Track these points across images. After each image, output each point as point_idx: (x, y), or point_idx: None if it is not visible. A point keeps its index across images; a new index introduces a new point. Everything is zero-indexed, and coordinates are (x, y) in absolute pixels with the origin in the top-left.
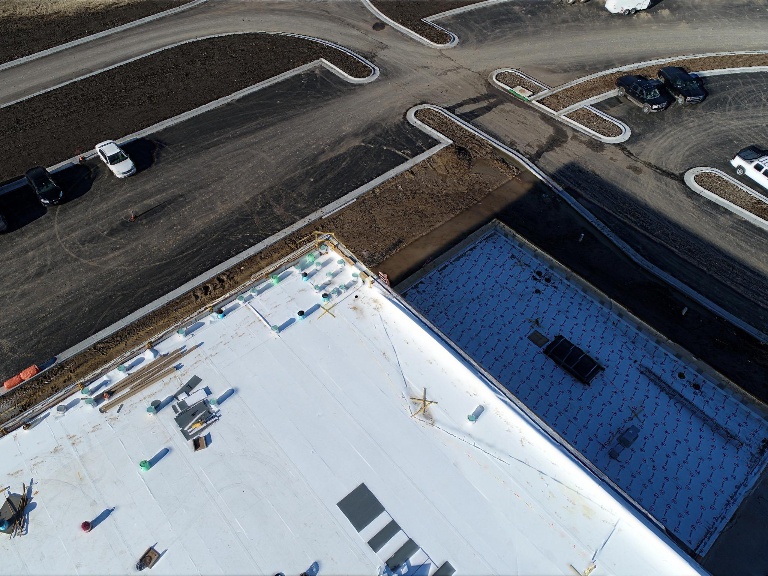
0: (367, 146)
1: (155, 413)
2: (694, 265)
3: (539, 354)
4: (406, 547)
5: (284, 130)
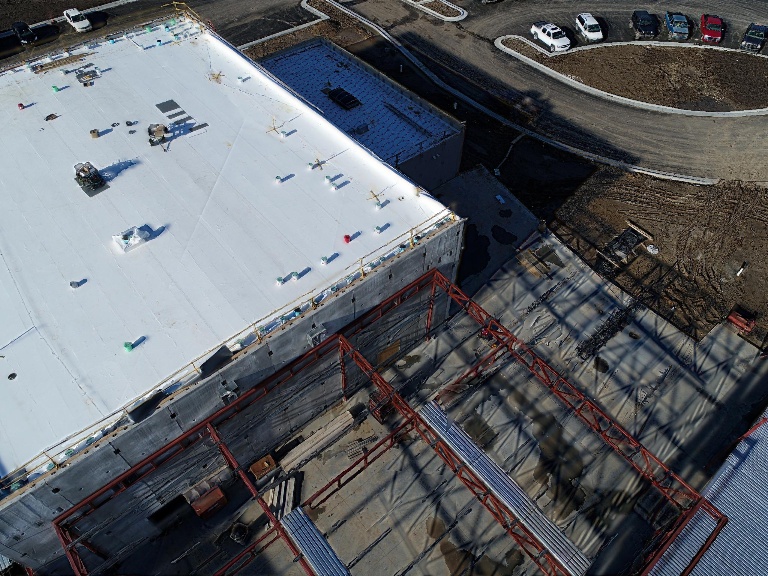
0: (266, 19)
1: (65, 74)
2: (478, 86)
3: (324, 97)
4: (186, 118)
5: (206, 9)
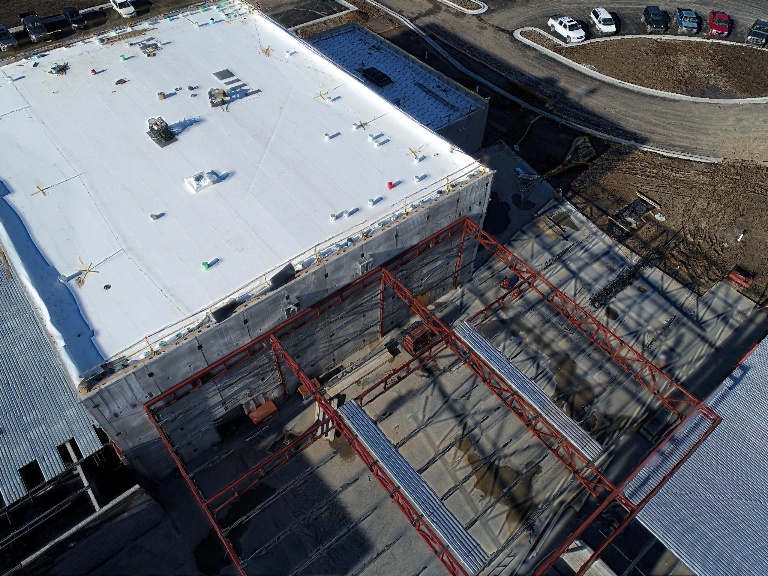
0: (298, 9)
1: (130, 46)
2: (498, 73)
3: (359, 76)
4: (241, 85)
5: None
